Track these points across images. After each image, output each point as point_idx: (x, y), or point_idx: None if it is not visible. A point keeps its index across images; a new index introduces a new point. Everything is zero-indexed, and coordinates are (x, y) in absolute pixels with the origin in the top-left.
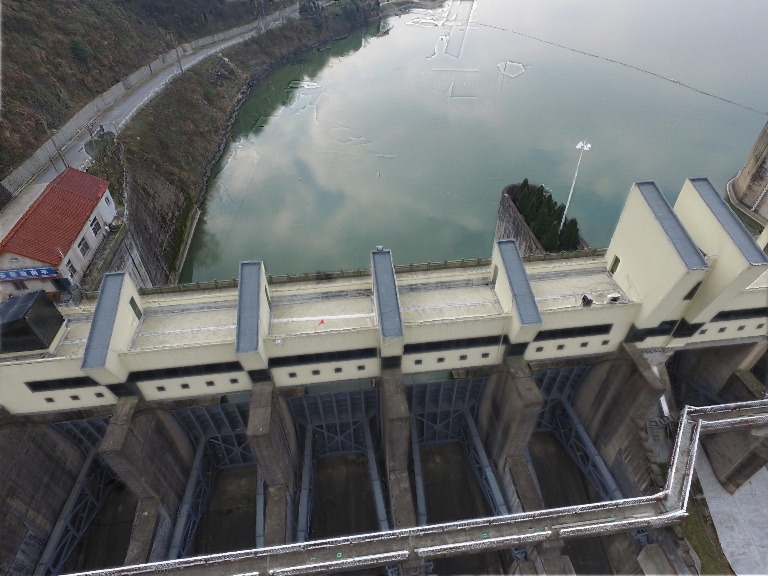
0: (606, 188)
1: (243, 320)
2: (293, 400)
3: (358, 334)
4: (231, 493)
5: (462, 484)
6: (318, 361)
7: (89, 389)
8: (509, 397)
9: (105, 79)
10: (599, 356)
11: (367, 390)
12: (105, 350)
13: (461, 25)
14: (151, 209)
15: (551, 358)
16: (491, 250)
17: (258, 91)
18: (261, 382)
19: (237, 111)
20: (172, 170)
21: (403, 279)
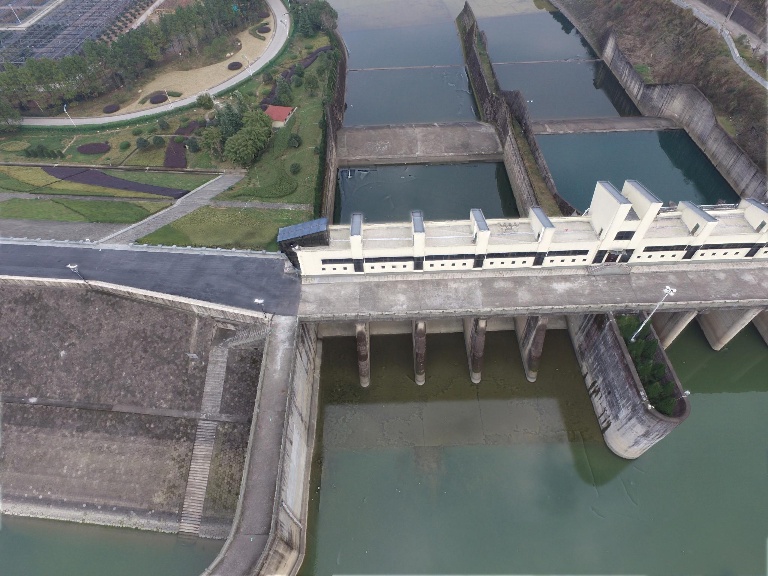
0: None
1: None
2: None
3: None
4: None
5: None
6: None
7: None
8: None
9: None
10: None
11: None
12: None
13: None
14: None
15: None
16: (643, 489)
17: None
18: None
19: None
20: None
21: (757, 233)
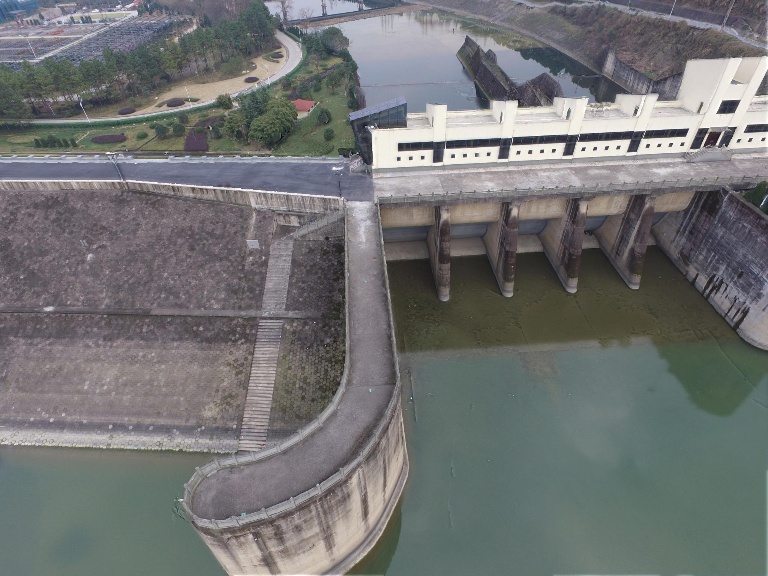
0: (639, 568)
1: None
2: None
3: None
4: None
5: None
6: None
7: None
8: None
9: None
10: None
11: None
12: None
13: None
14: None
15: None
16: None
17: None
18: None
19: None
20: None
21: None
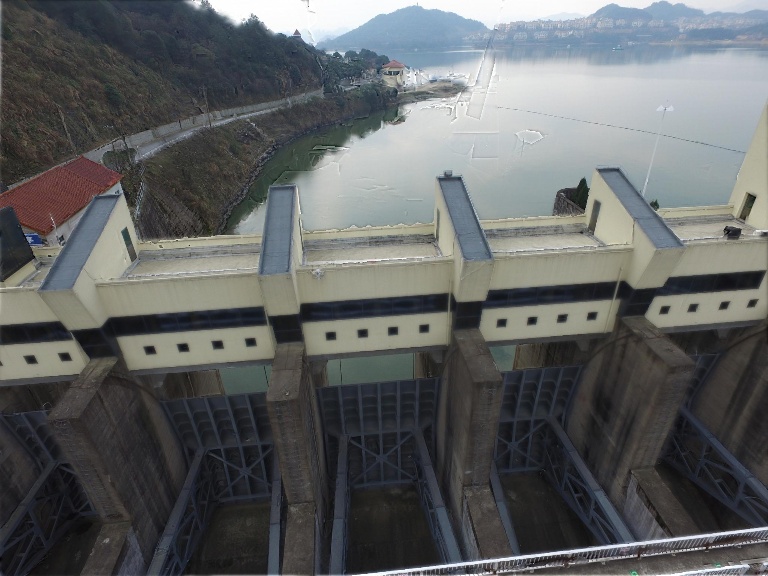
0: None
1: (270, 242)
2: (325, 392)
3: (425, 268)
4: (232, 537)
5: (551, 530)
6: (367, 314)
7: (51, 345)
8: (632, 372)
9: (135, 124)
10: (734, 335)
11: (424, 379)
12: (77, 271)
13: (482, 88)
14: (166, 224)
15: (677, 327)
16: None
17: (282, 157)
18: (288, 342)
19: (261, 167)
20: (192, 197)
21: None
